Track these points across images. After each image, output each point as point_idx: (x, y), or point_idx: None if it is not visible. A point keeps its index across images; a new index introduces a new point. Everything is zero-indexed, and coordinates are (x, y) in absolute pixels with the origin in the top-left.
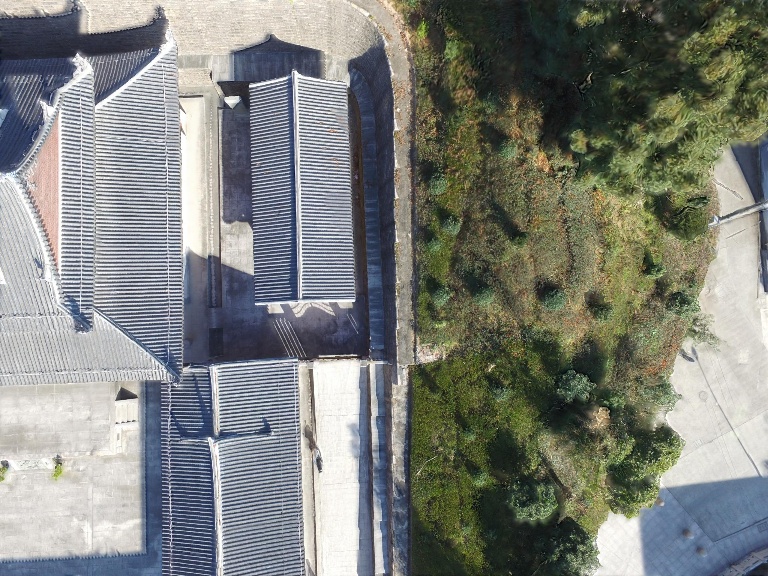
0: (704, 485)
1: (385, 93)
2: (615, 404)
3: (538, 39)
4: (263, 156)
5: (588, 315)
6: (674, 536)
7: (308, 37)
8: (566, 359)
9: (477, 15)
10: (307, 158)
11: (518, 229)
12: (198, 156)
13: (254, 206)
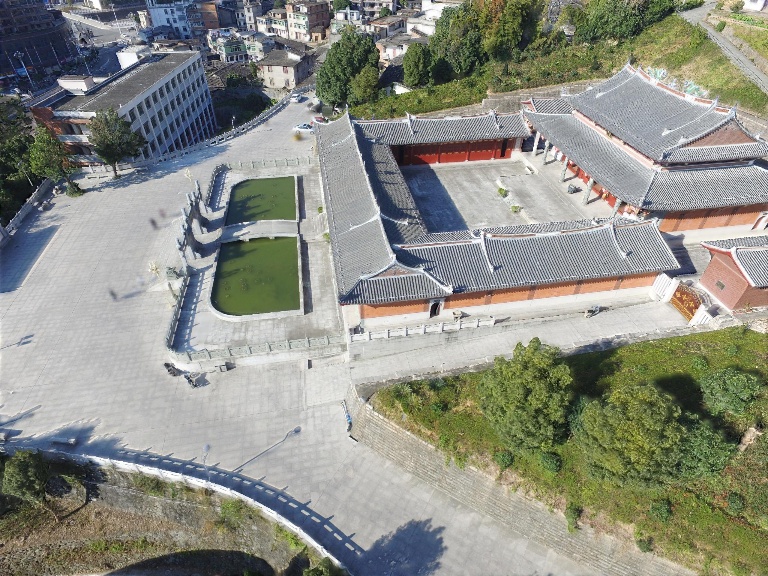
0: None
1: None
2: None
3: None
4: None
5: None
6: None
7: None
8: None
9: None
10: None
11: None
12: None
13: (761, 236)
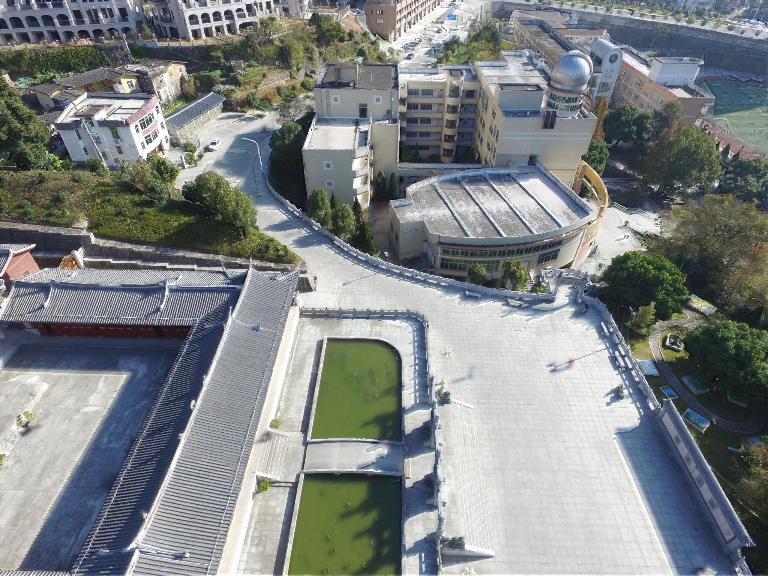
0: None
1: None
2: None
3: None
4: None
5: None
6: None
7: None
8: None
9: None
10: None
11: (40, 181)
12: None
13: None
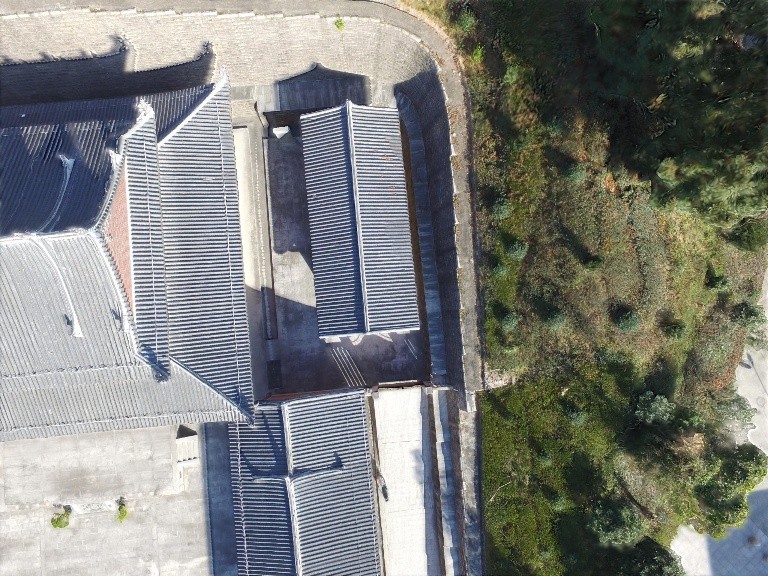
0: (766, 491)
1: (438, 117)
2: (695, 423)
3: (602, 60)
4: (319, 187)
5: (660, 334)
6: (739, 544)
7: (354, 64)
8: (638, 378)
9: (537, 38)
10: (365, 188)
11: (589, 252)
12: (245, 187)
13: (313, 238)
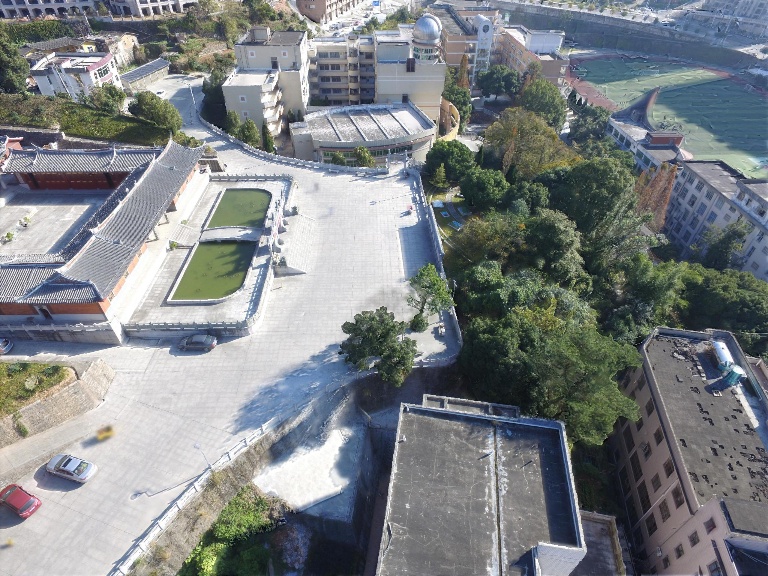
0: None
1: None
2: None
3: None
4: None
5: None
6: (185, 127)
7: None
8: None
9: None
10: None
11: None
12: None
13: None
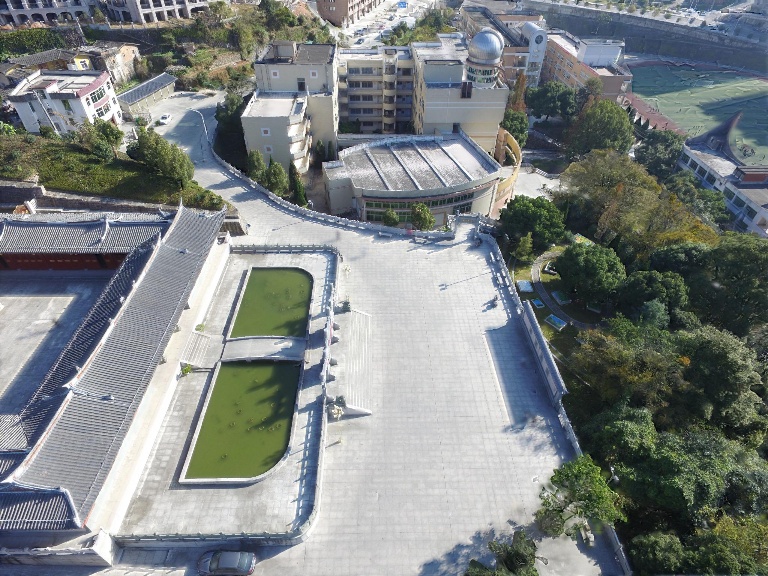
0: None
1: None
2: None
3: None
4: None
5: None
6: (195, 166)
7: None
8: None
9: None
10: None
11: None
12: None
13: None
